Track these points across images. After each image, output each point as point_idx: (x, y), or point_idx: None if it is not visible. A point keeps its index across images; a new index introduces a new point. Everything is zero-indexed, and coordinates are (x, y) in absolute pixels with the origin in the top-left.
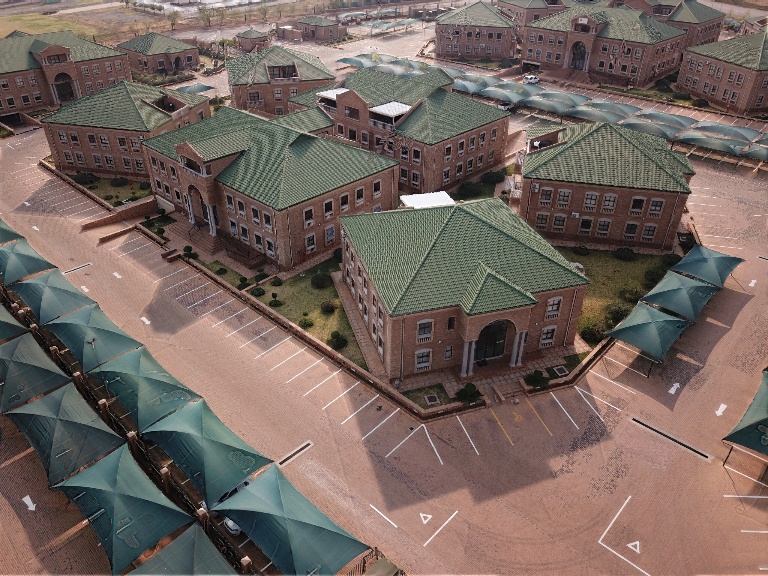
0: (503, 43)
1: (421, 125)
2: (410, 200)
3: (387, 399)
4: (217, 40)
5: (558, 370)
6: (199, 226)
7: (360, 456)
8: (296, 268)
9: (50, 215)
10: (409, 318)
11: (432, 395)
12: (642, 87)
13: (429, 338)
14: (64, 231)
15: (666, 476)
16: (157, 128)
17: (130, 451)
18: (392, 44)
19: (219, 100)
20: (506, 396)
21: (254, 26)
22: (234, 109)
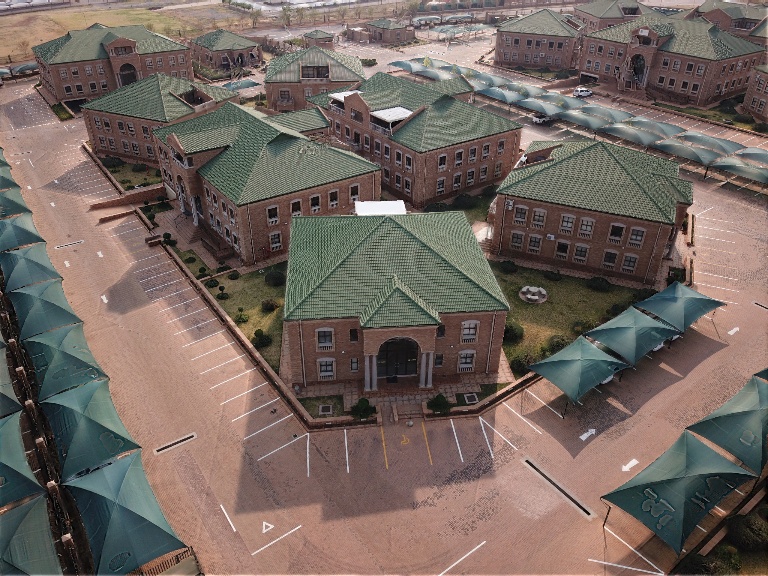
0: (564, 53)
1: (417, 132)
2: (362, 206)
3: (285, 403)
4: (194, 38)
5: (468, 397)
6: (186, 215)
7: (234, 455)
8: (258, 264)
9: (70, 193)
10: (307, 324)
11: (327, 405)
12: (703, 107)
13: (330, 347)
14: (75, 209)
15: (534, 527)
16: (177, 119)
17: (21, 418)
18: (456, 49)
19: (263, 96)
20: (402, 417)
21: (330, 27)
22: (235, 105)
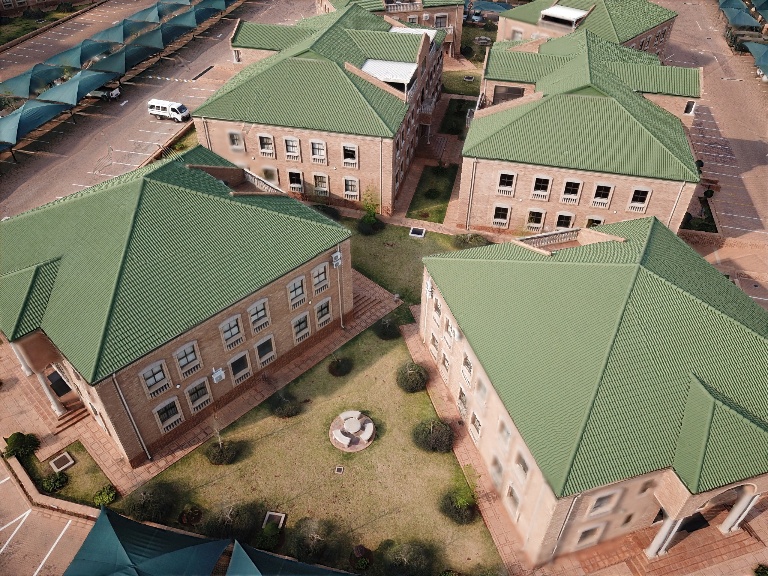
0: None
1: None
2: (576, 15)
3: None
4: None
5: None
6: None
7: None
8: None
9: None
10: None
11: None
12: None
13: None
14: None
15: None
16: None
17: None
18: None
19: (155, 488)
20: None
21: None
22: (590, 73)
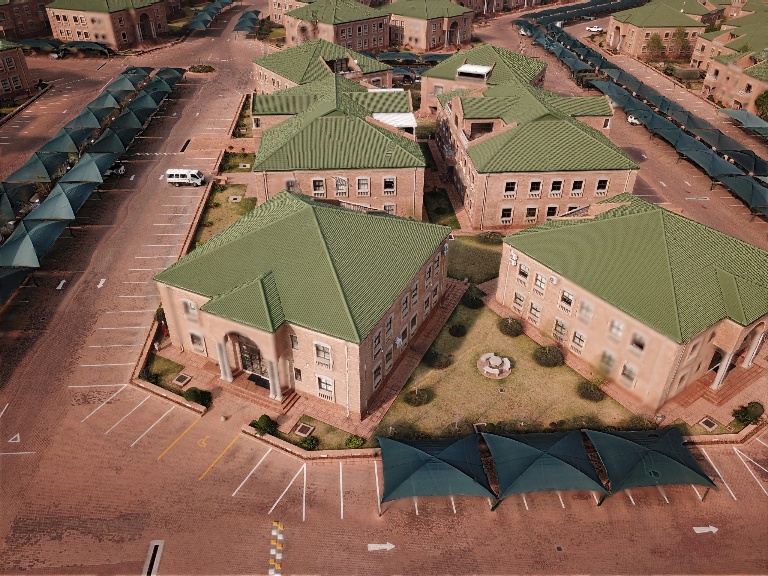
0: None
1: None
2: (485, 70)
3: None
4: None
5: None
6: None
7: None
8: None
9: None
10: None
11: None
12: None
13: None
14: None
15: None
16: None
17: None
18: None
19: None
20: None
21: None
22: None
